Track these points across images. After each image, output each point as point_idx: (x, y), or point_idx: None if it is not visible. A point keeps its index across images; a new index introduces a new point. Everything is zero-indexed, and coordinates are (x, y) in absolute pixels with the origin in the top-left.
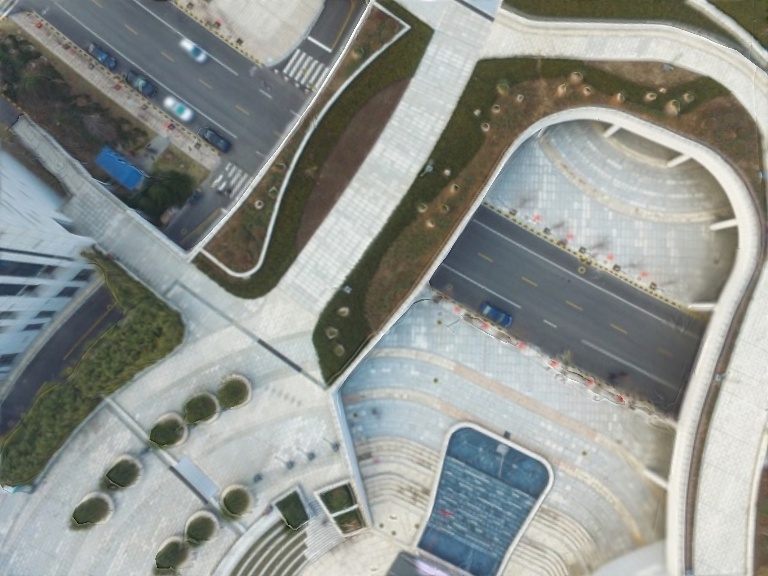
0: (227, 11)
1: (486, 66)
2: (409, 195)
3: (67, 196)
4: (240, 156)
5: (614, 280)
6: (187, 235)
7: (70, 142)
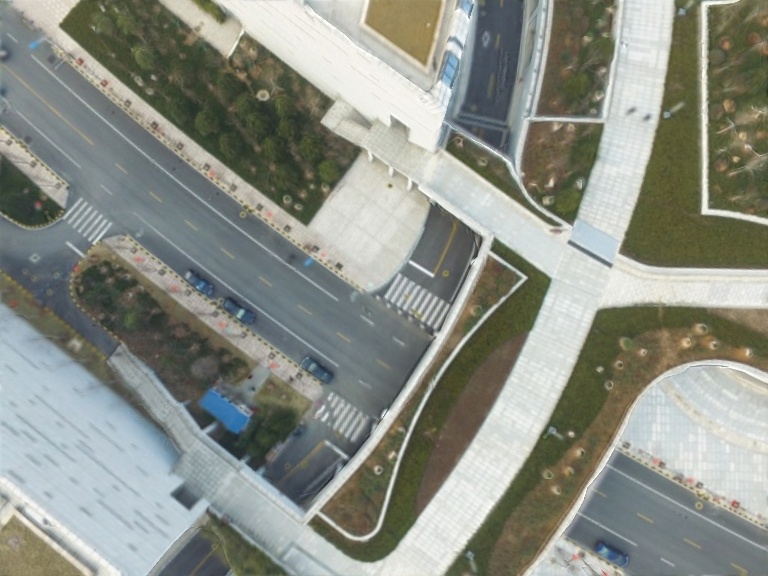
0: (325, 234)
1: (606, 317)
2: (532, 458)
3: (177, 453)
4: (342, 385)
5: (735, 521)
6: (291, 470)
7: (170, 376)
